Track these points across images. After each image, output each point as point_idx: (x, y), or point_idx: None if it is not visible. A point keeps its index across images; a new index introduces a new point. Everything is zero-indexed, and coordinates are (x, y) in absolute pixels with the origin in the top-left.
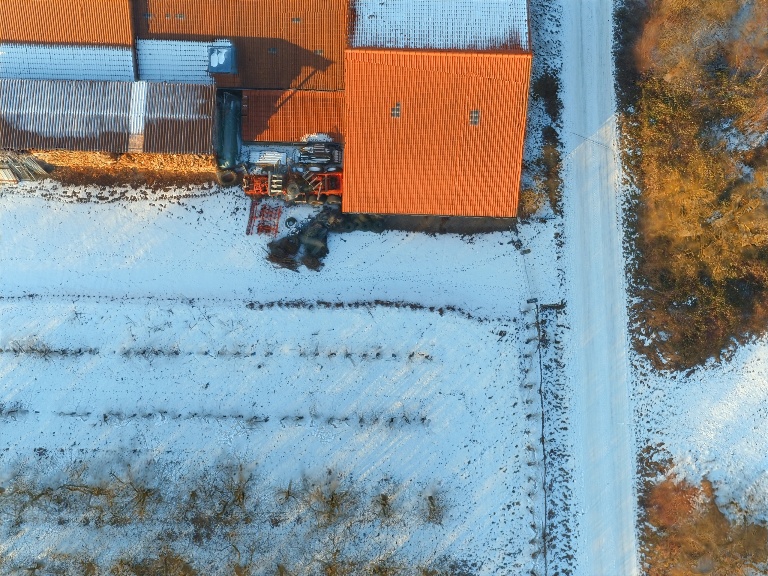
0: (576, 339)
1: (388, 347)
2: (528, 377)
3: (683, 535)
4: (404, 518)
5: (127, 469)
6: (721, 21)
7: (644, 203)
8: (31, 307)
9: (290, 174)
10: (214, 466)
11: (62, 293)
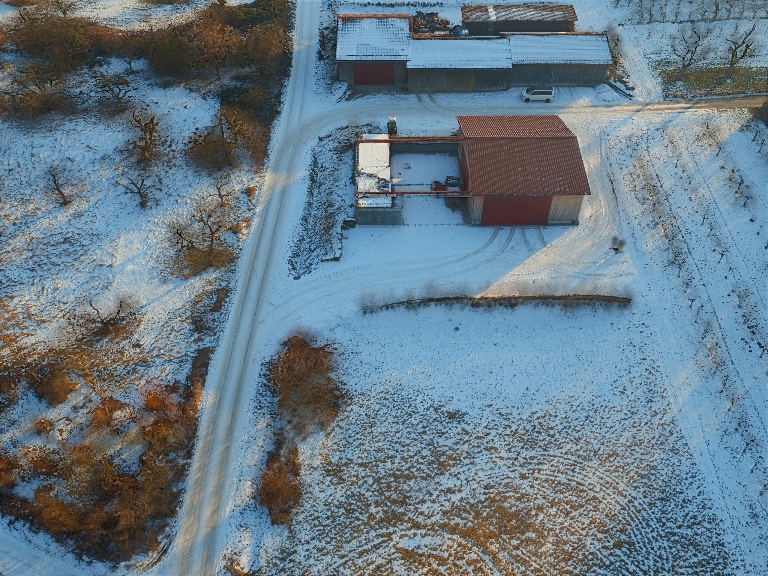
0: (317, 5)
1: None
2: None
3: None
4: None
5: None
6: None
7: (285, 30)
8: (524, 1)
9: (431, 21)
10: None
11: None
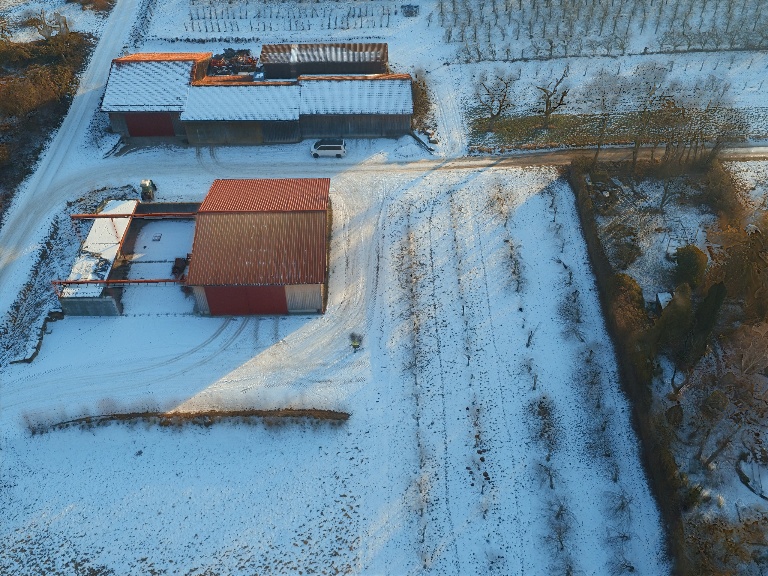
0: None
1: (202, 32)
2: (146, 30)
3: (99, 0)
4: (204, 0)
5: (309, 6)
6: (5, 124)
7: (75, 71)
8: None
9: None
10: (276, 8)
11: (338, 41)
